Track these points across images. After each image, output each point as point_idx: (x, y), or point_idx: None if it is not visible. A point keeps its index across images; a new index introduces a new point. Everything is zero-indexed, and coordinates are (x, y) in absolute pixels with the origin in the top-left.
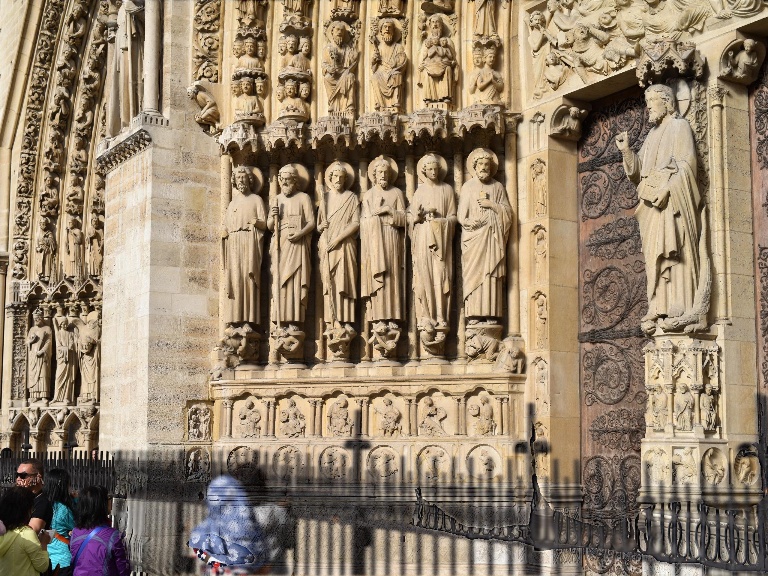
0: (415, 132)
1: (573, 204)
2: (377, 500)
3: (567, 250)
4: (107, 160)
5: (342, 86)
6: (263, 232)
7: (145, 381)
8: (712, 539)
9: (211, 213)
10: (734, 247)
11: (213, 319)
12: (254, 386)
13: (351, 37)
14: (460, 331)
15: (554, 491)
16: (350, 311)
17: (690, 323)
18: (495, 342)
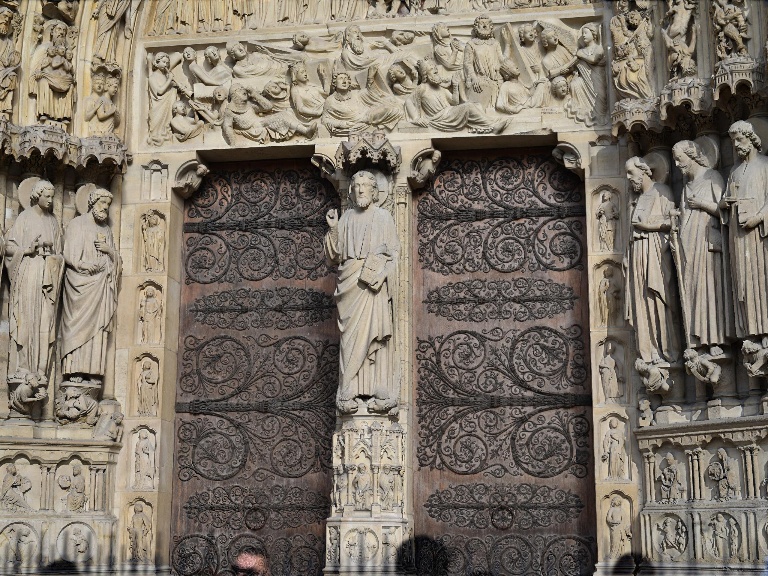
0: (39, 149)
1: (179, 264)
2: None
3: (174, 312)
4: None
5: None
6: None
7: None
8: None
9: None
10: (409, 337)
11: None
12: None
13: None
14: (50, 388)
15: (158, 574)
16: None
17: (394, 406)
18: (98, 405)
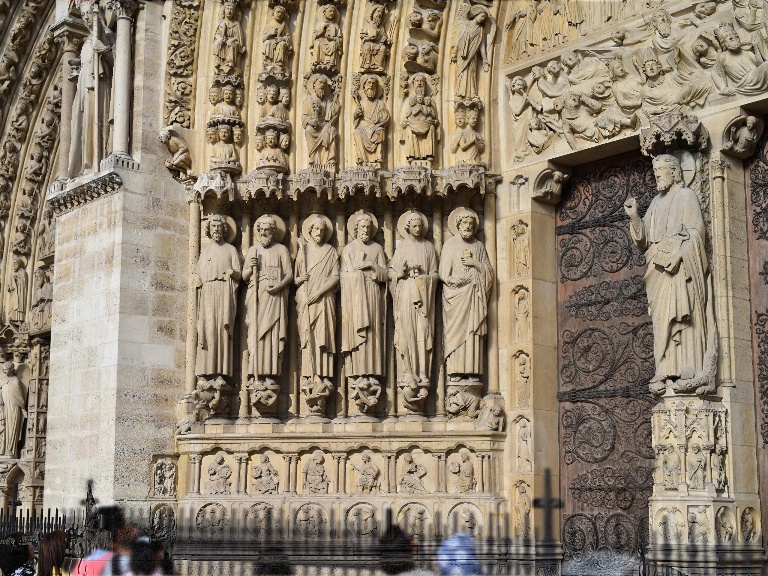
0: (401, 188)
1: (552, 265)
2: (356, 558)
3: (547, 310)
4: (62, 202)
5: (324, 139)
6: (238, 283)
7: (111, 434)
8: None
9: (179, 261)
10: (736, 313)
11: (179, 371)
12: (226, 441)
13: (331, 91)
14: (439, 388)
15: (538, 549)
16: (329, 365)
17: (702, 385)
18: (477, 400)
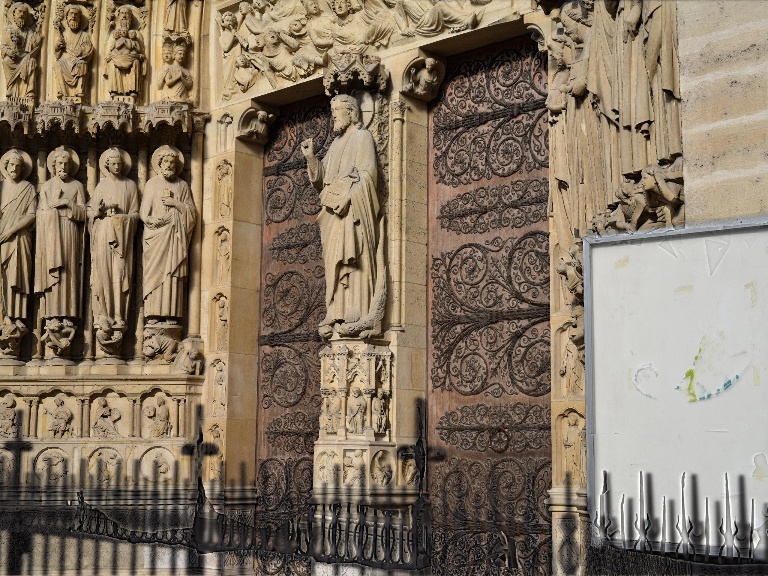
0: (99, 124)
1: (258, 207)
2: (43, 504)
3: (250, 253)
4: None
5: (22, 71)
6: None
7: None
8: (369, 539)
9: None
10: (409, 257)
11: None
12: None
13: (34, 20)
14: (138, 331)
15: (228, 493)
16: (22, 306)
17: (365, 329)
18: (174, 343)
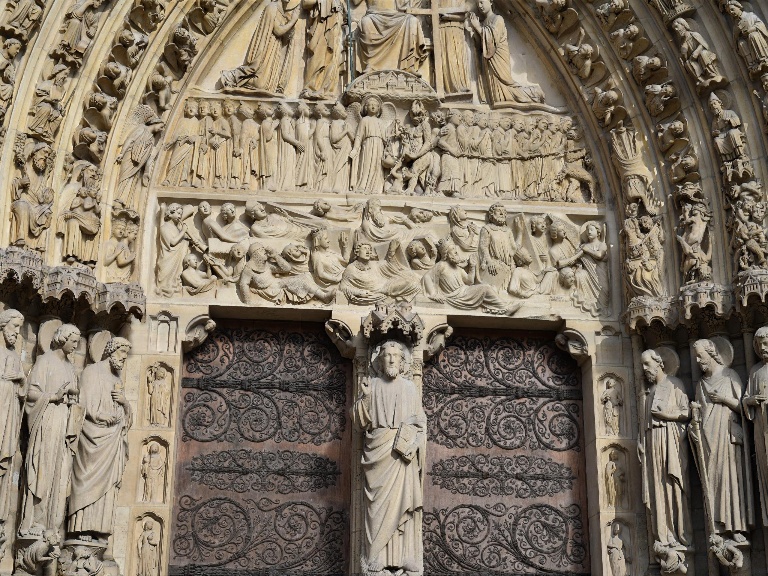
0: (73, 292)
1: None
2: None
3: None
4: None
5: None
6: None
7: None
8: None
9: None
10: None
11: None
12: None
13: None
14: None
15: None
16: None
17: None
18: (103, 566)
